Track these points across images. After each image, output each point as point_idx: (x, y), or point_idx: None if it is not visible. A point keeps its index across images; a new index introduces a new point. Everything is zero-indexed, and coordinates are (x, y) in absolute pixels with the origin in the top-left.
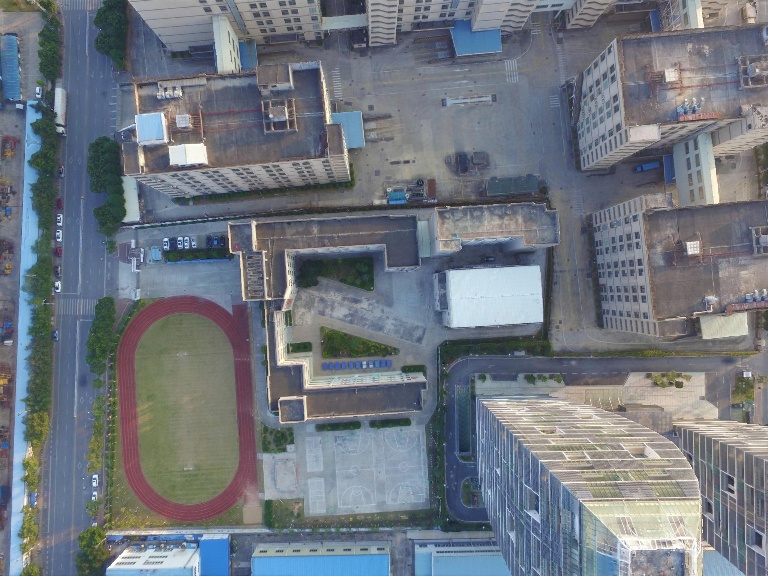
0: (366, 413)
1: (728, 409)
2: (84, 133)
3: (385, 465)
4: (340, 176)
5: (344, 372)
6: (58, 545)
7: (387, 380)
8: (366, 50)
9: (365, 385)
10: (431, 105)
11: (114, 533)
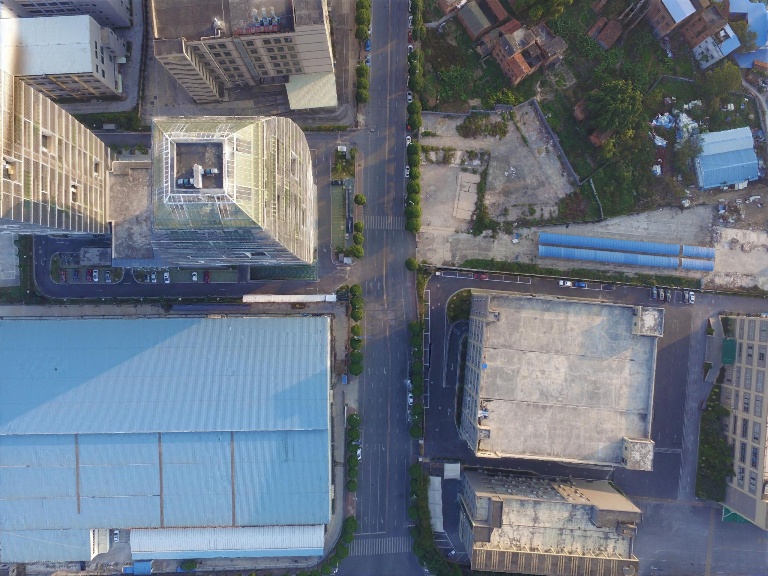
0: None
1: (328, 187)
2: None
3: None
4: None
5: None
6: None
7: None
8: None
9: None
10: None
11: None
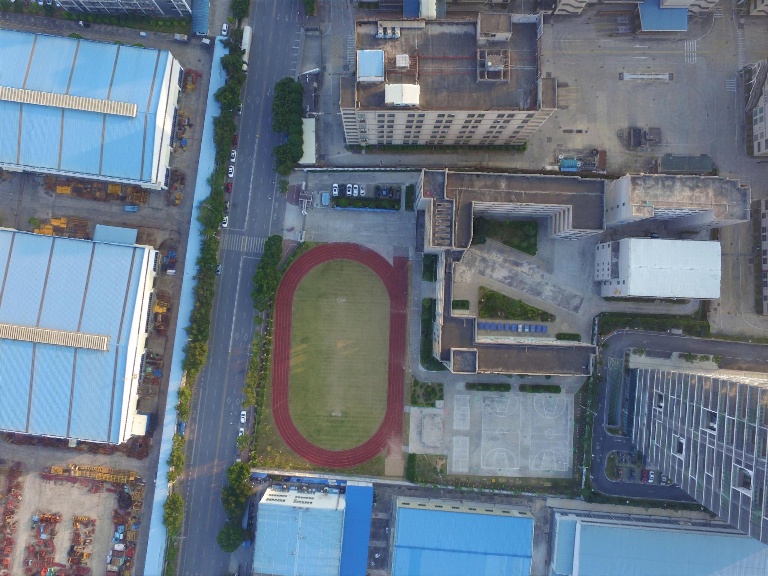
0: (534, 372)
1: None
2: (264, 73)
3: (531, 430)
4: (520, 137)
5: (499, 333)
6: (200, 477)
7: (552, 343)
8: (549, 18)
9: (536, 344)
10: (608, 78)
11: (258, 471)
